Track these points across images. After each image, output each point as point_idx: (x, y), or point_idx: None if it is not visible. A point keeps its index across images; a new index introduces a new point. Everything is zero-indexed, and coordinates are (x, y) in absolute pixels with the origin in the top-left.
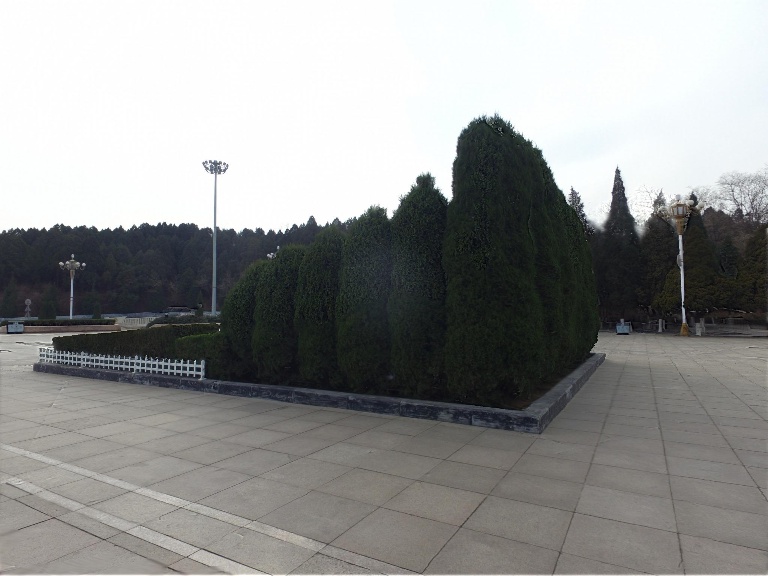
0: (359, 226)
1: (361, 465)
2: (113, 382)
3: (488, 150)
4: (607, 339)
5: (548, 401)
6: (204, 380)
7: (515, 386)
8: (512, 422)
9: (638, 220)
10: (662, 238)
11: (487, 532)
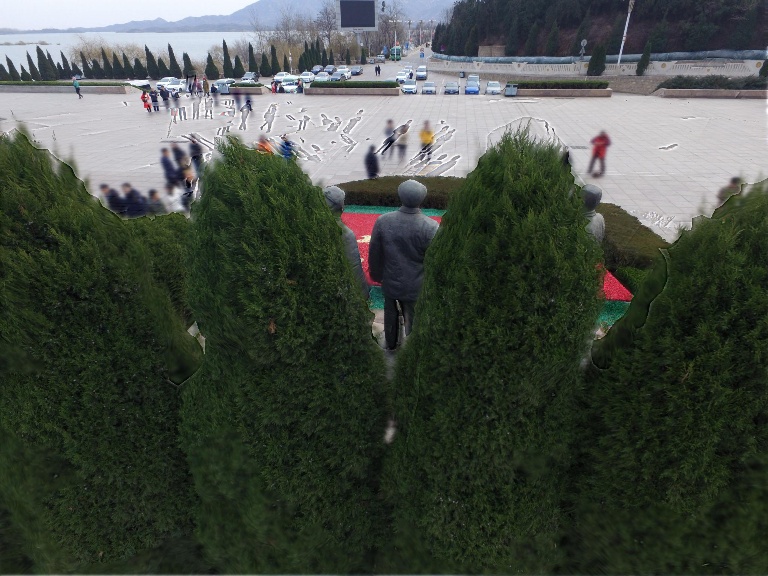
0: None
1: None
2: None
3: None
4: None
5: None
6: None
7: None
8: None
9: None
10: None
11: None
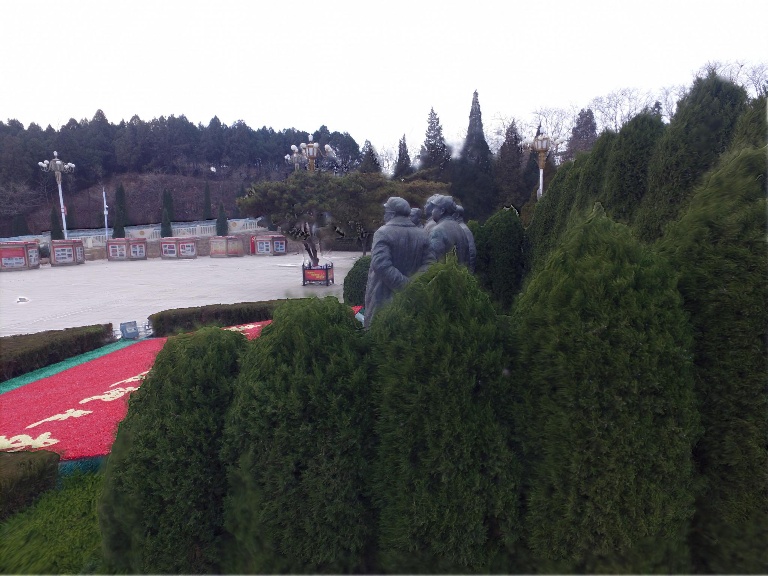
0: (610, 292)
1: None
2: None
3: None
4: None
5: None
6: None
7: None
8: None
9: (492, 148)
10: (513, 168)
11: None
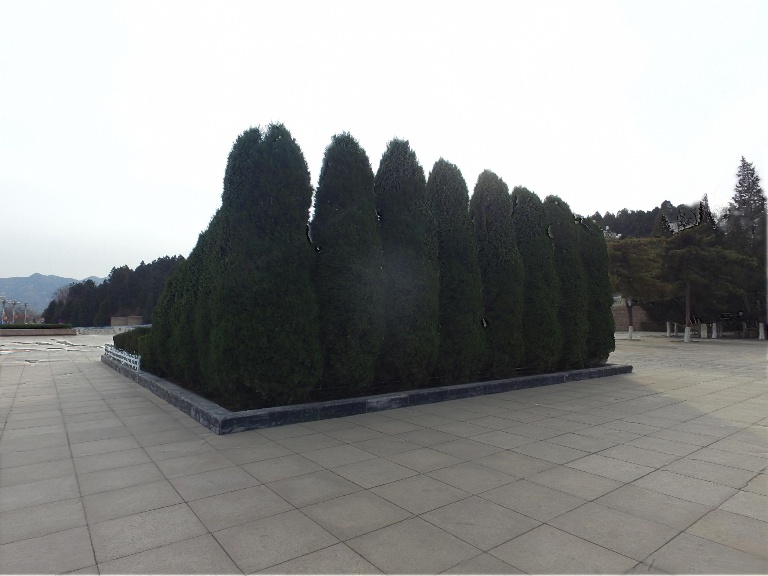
0: None
1: (7, 440)
2: (112, 371)
3: (237, 160)
4: (753, 349)
5: (297, 406)
6: (138, 372)
7: (254, 388)
8: (211, 422)
9: None
10: None
11: None
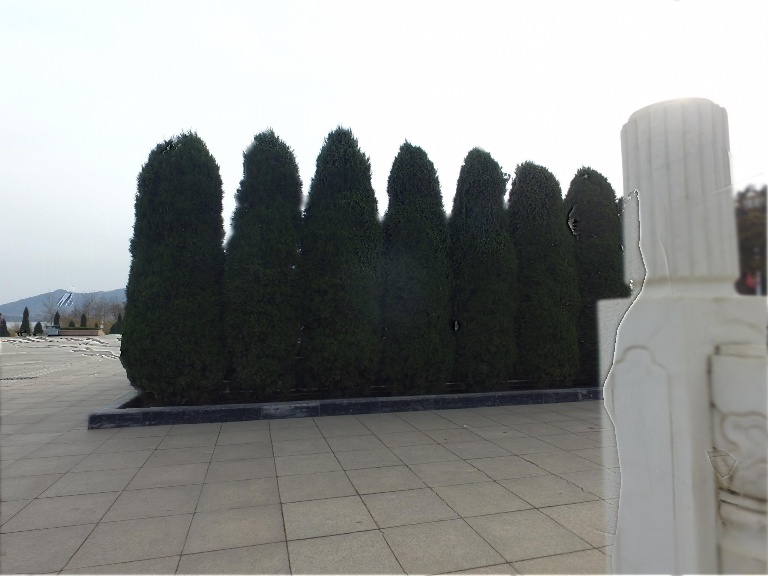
0: None
1: None
2: None
3: (143, 172)
4: None
5: (179, 408)
6: None
7: None
8: None
9: None
10: None
11: None
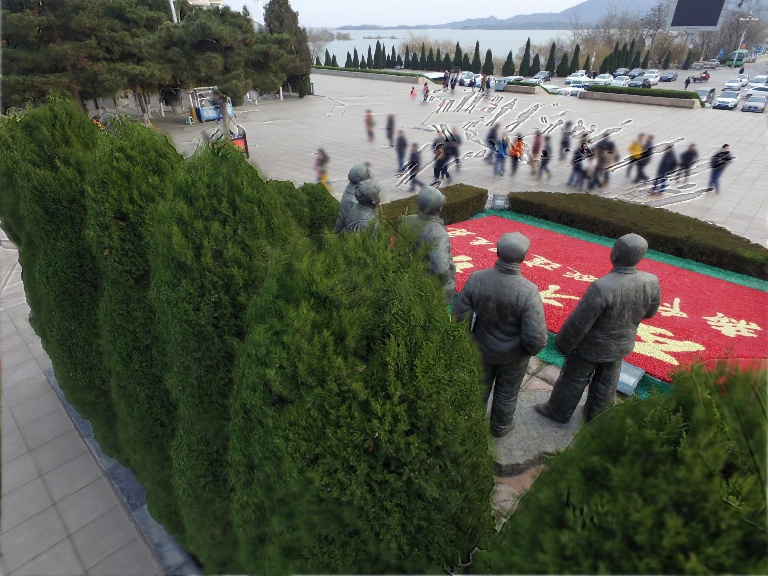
0: None
1: None
2: None
3: None
4: None
5: None
6: None
7: None
8: None
9: None
10: None
11: (1, 323)
